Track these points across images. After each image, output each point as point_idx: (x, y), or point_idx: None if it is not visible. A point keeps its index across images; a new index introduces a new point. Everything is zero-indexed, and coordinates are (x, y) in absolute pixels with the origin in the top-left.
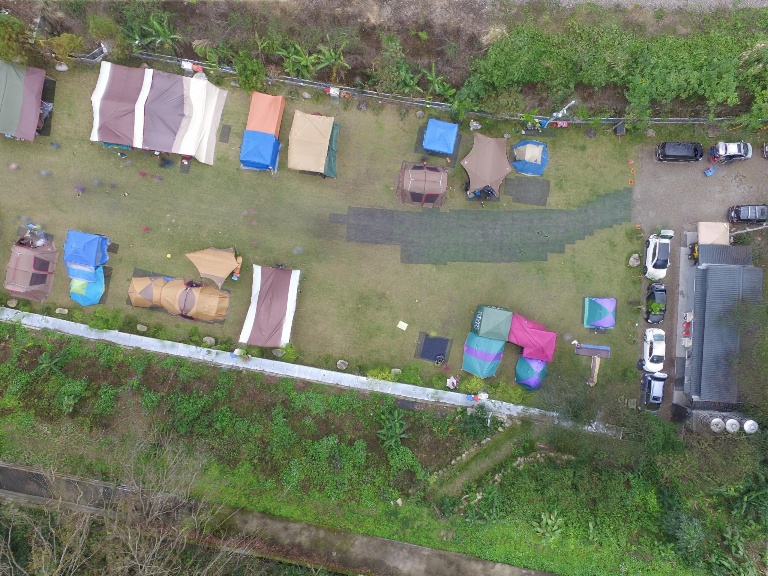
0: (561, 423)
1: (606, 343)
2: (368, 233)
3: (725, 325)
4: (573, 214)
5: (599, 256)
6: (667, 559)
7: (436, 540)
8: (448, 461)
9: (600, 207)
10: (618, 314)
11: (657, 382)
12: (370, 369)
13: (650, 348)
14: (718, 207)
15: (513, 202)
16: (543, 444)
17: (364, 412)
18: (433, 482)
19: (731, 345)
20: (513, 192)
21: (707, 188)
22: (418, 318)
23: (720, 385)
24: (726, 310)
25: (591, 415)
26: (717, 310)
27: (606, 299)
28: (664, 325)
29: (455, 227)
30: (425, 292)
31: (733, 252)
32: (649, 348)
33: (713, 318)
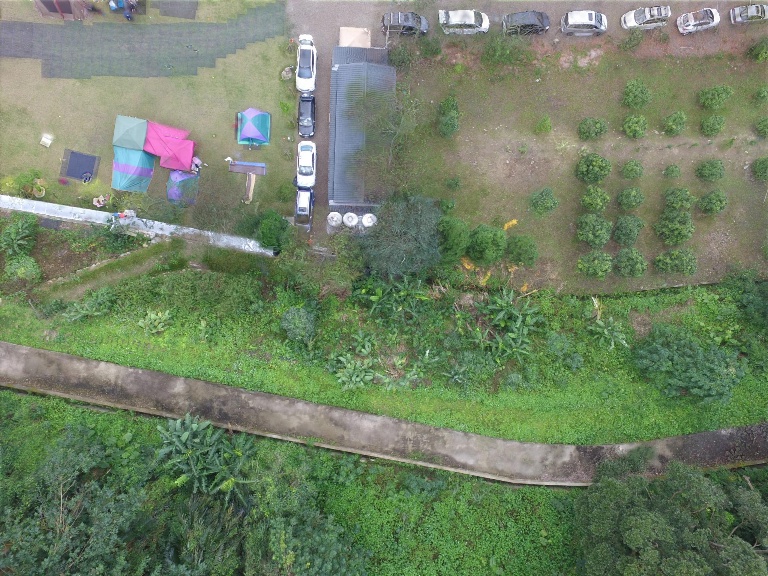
0: (216, 242)
1: (261, 160)
2: (6, 46)
3: (353, 123)
4: (223, 27)
5: (251, 70)
6: (284, 357)
7: (38, 340)
8: (73, 270)
9: (252, 20)
10: (273, 130)
11: (302, 192)
12: (13, 188)
13: (298, 160)
14: (374, 20)
15: (160, 15)
16: (196, 263)
17: (1, 229)
18: (21, 273)
19: (358, 143)
20: (160, 5)
21: (362, 1)
22: (62, 135)
23: (349, 185)
24: (353, 108)
25: (246, 233)
26: (346, 109)
27: (249, 108)
28: (320, 140)
29: (99, 40)
30: (69, 107)
31: (368, 54)
32: (298, 160)
33: (342, 117)
